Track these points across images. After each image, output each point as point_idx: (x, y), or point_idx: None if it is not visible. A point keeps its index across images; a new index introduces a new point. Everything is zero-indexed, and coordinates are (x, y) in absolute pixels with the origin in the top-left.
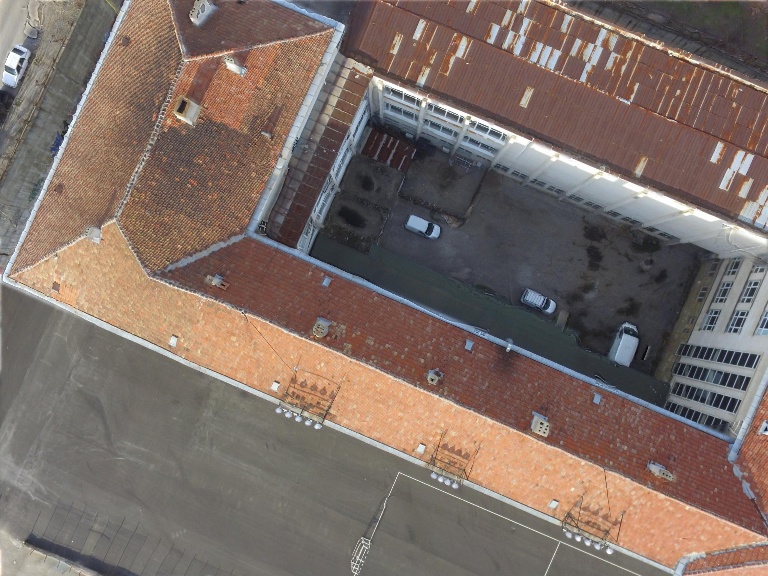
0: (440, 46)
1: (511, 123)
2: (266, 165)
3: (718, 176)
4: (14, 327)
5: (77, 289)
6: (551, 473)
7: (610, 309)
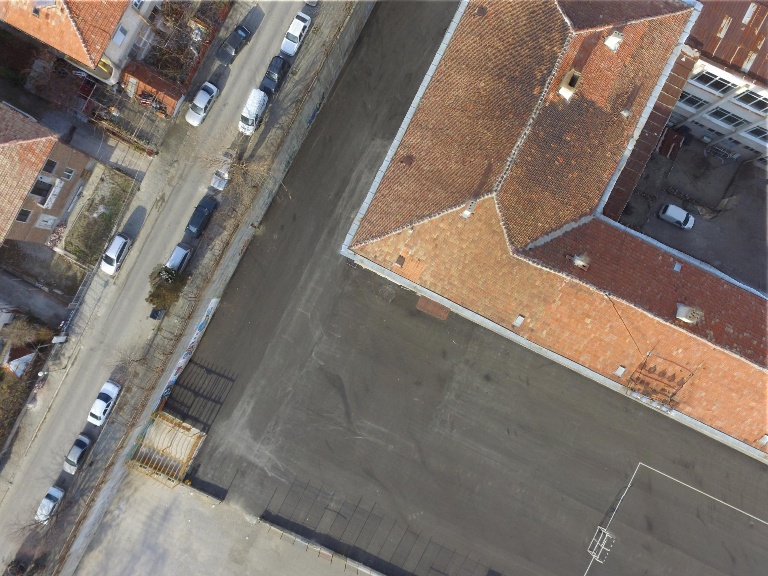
0: None
1: None
2: (619, 145)
3: None
4: (256, 301)
5: (424, 264)
6: None
7: None
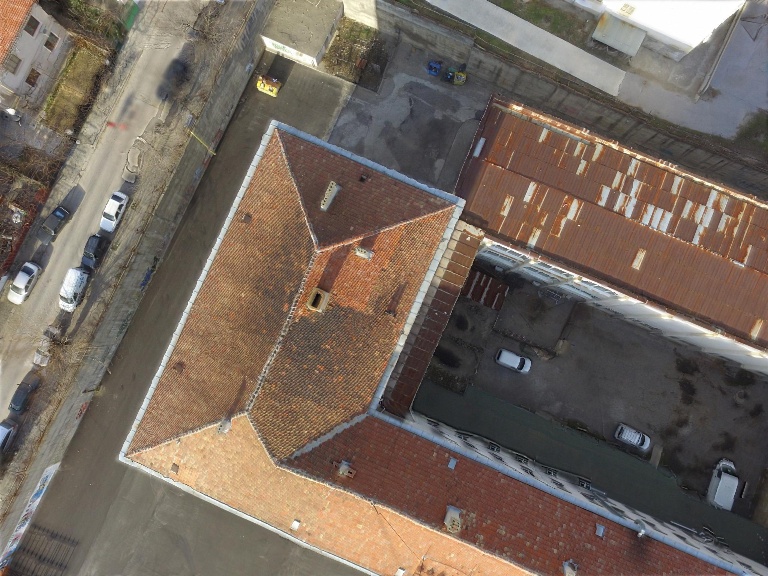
0: (551, 208)
1: (623, 284)
2: (389, 342)
3: None
4: (97, 463)
5: (197, 472)
6: None
7: (705, 443)
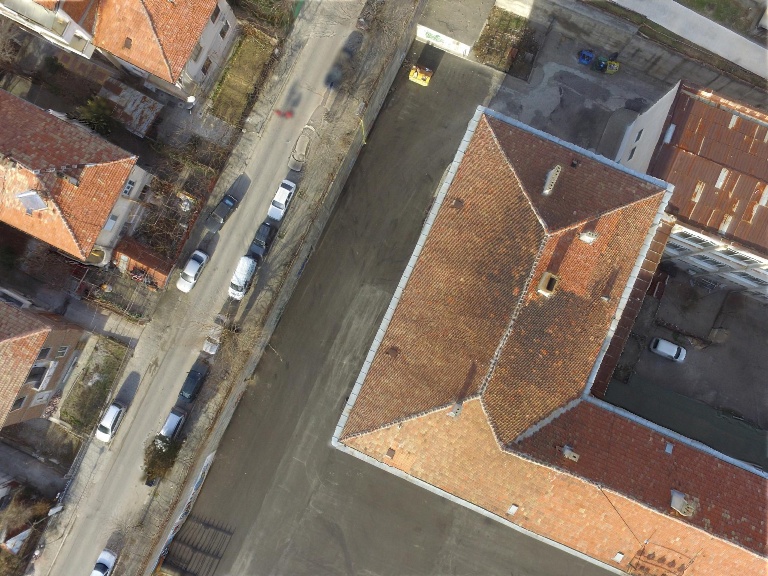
0: (743, 194)
1: None
2: (601, 327)
3: None
4: (252, 451)
5: (414, 456)
6: None
7: None
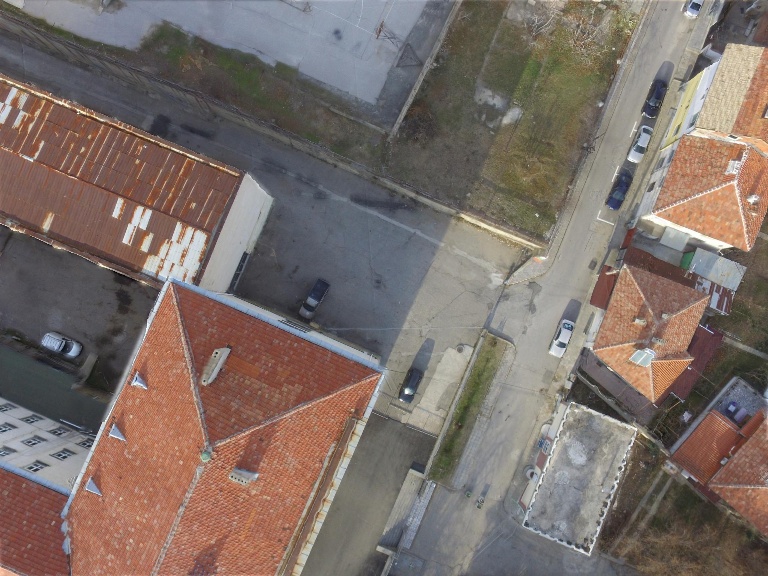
0: None
1: None
2: None
3: (121, 231)
4: None
5: None
6: None
7: None
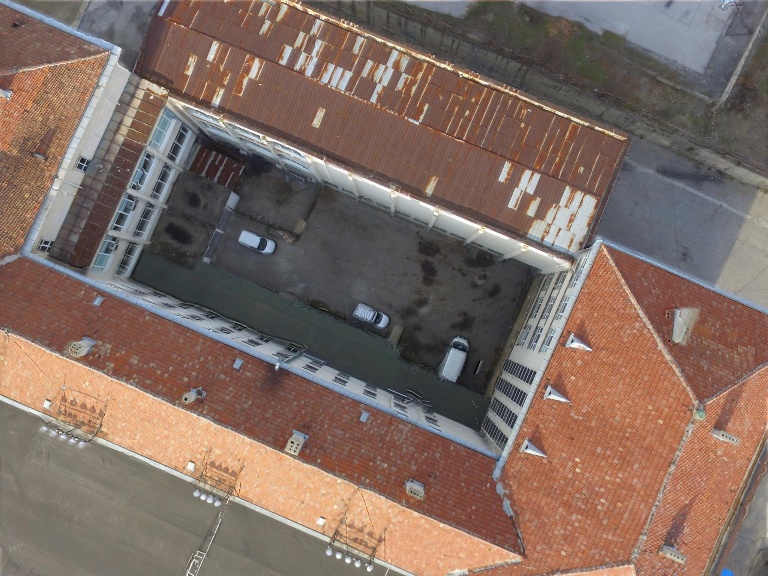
0: (233, 67)
1: (304, 143)
2: (41, 186)
3: (506, 195)
4: None
5: None
6: (313, 491)
7: (444, 323)
